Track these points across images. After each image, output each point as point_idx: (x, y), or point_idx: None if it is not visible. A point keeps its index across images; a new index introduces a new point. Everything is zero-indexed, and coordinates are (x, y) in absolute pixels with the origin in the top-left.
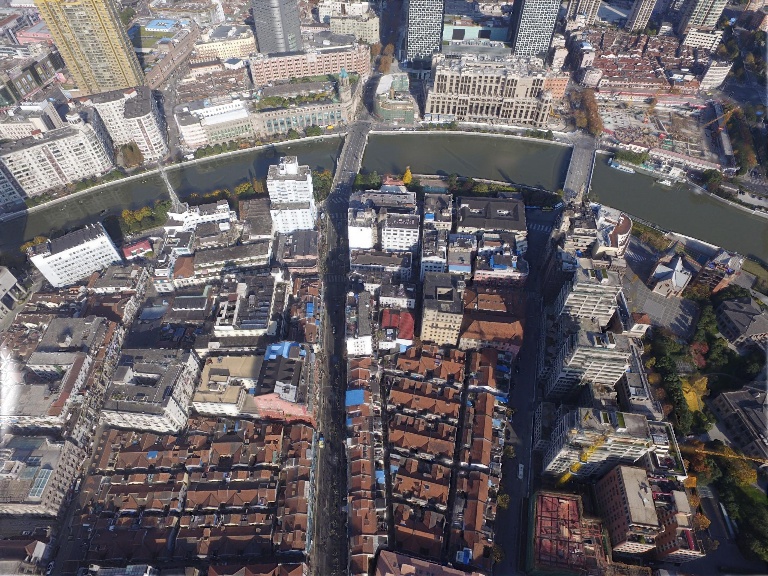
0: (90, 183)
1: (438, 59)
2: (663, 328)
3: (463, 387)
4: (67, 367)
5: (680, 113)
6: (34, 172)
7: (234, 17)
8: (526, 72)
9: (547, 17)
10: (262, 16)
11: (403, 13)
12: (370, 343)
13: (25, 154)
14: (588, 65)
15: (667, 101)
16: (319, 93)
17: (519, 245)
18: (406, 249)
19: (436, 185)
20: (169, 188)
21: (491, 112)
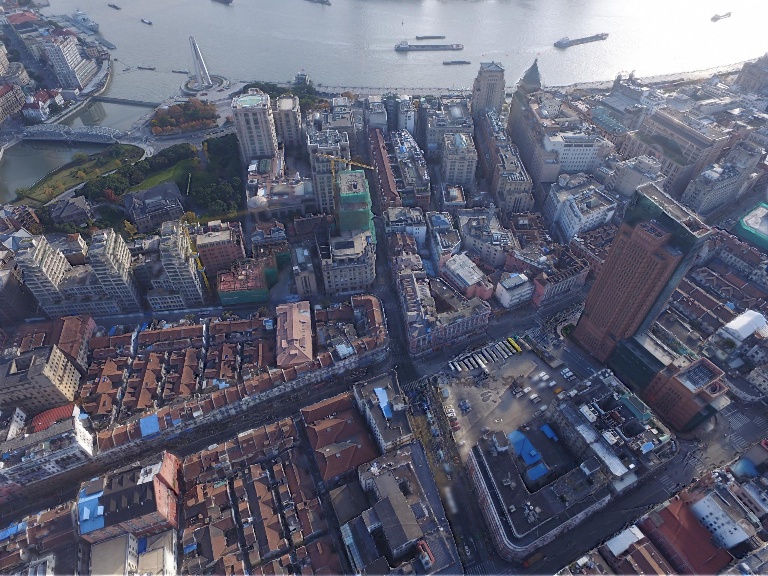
0: None
1: None
2: None
3: None
4: None
5: None
6: None
7: None
8: None
9: None
10: None
11: None
12: (81, 427)
13: None
14: None
15: None
16: None
17: None
18: None
19: None
20: None
21: None
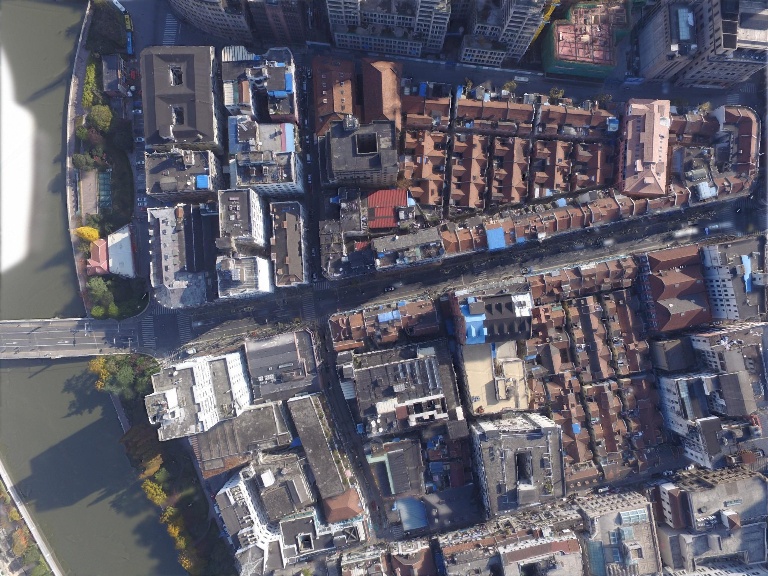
0: None
1: None
2: None
3: None
4: None
5: None
6: None
7: None
8: None
9: None
10: None
11: None
12: None
13: None
14: None
15: None
16: None
17: (243, 57)
18: (261, 213)
19: (94, 189)
20: None
21: None
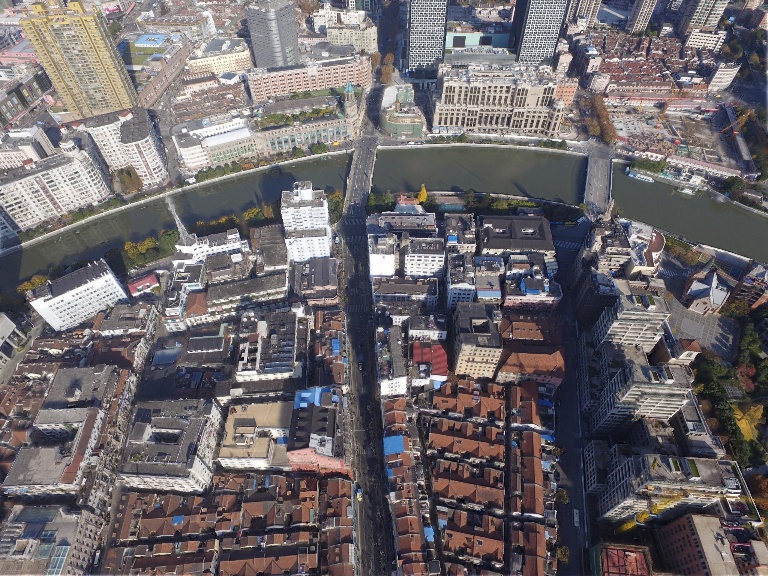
0: (87, 213)
1: (444, 69)
2: (705, 349)
3: (505, 425)
4: (78, 425)
5: (691, 117)
6: (27, 204)
7: (225, 29)
8: (536, 81)
9: (552, 22)
10: (258, 29)
11: (399, 20)
12: (405, 383)
13: (17, 186)
14: (594, 70)
15: (678, 105)
16: (323, 108)
17: (549, 267)
18: (430, 275)
19: (452, 202)
20: (177, 220)
21: (501, 122)
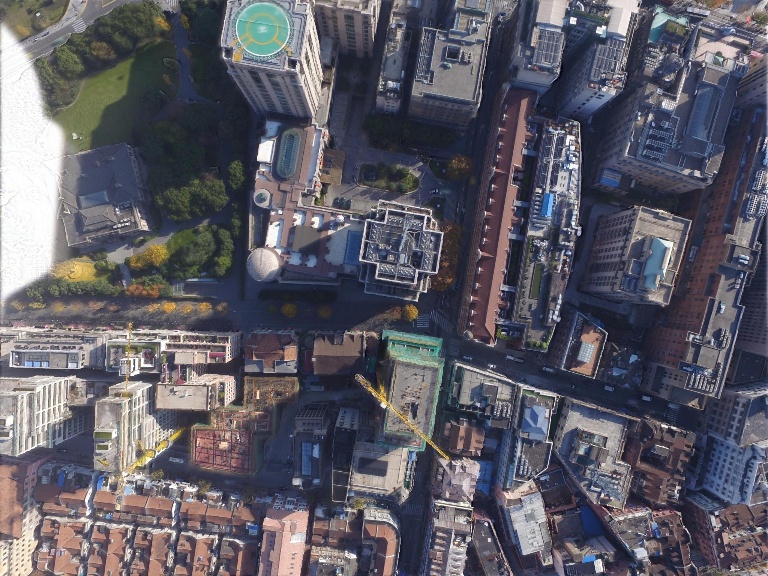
0: None
1: None
2: None
3: (90, 516)
4: None
5: None
6: None
7: None
8: None
9: None
10: None
11: None
12: None
13: None
14: None
15: None
16: None
17: None
18: None
19: None
20: None
21: None
